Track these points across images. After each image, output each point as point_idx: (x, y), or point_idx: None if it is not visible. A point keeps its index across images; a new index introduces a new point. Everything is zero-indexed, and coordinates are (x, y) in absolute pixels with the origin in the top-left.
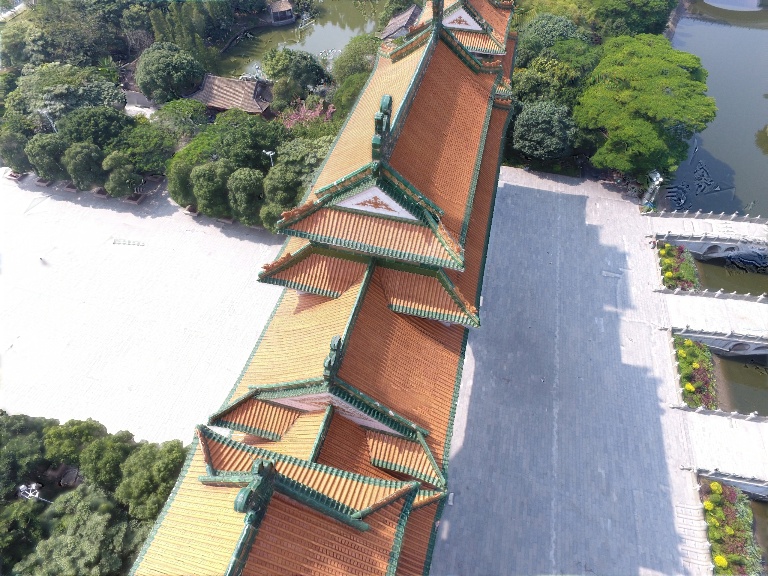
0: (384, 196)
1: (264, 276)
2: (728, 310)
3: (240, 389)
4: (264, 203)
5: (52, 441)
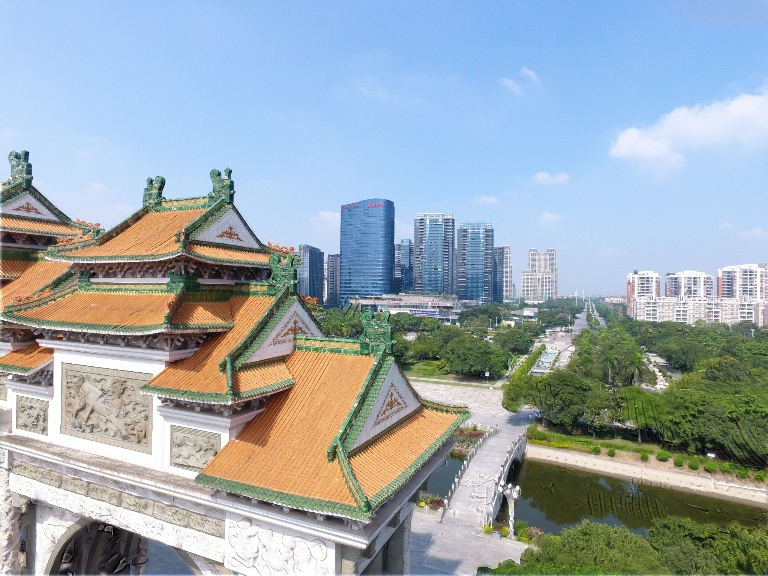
0: (34, 202)
1: None
2: None
3: None
4: None
5: None
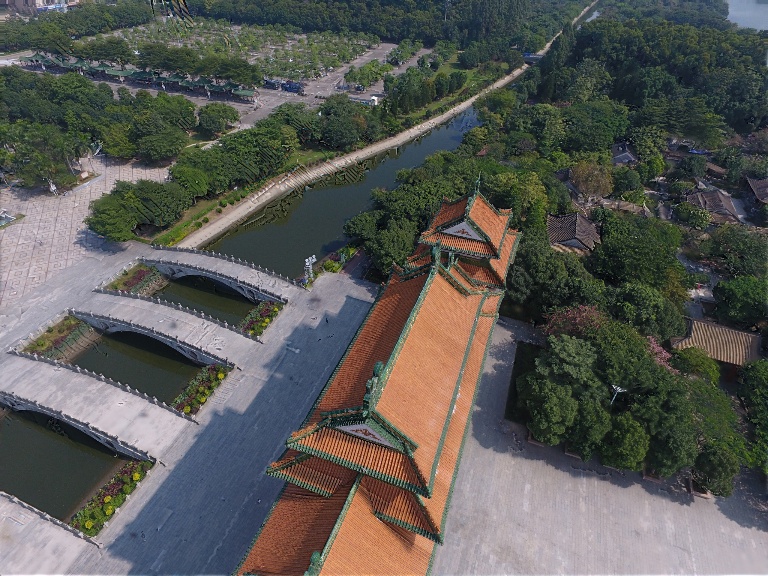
0: None
1: None
2: (8, 553)
3: (495, 304)
4: None
5: (635, 424)
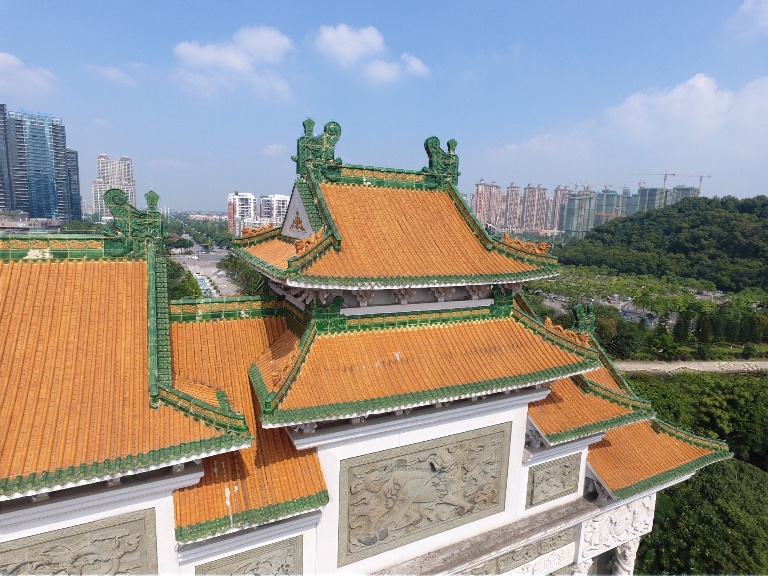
0: None
1: None
2: None
3: (152, 440)
4: None
5: None
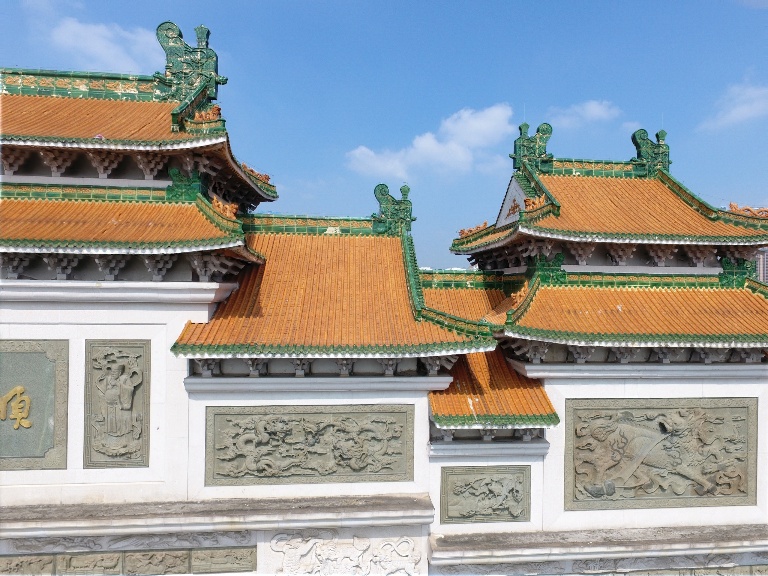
0: None
1: None
2: None
3: (420, 338)
4: None
5: None
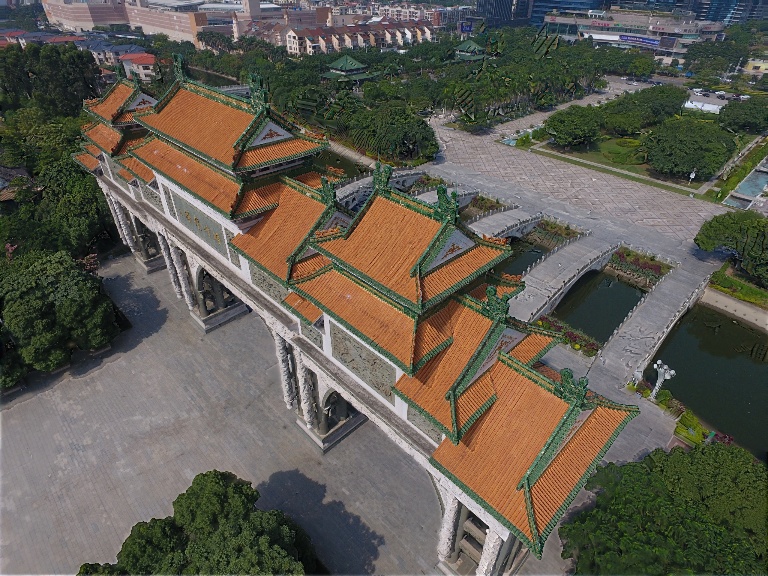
0: (274, 127)
1: (232, 214)
2: None
3: (279, 272)
4: (19, 348)
5: None
